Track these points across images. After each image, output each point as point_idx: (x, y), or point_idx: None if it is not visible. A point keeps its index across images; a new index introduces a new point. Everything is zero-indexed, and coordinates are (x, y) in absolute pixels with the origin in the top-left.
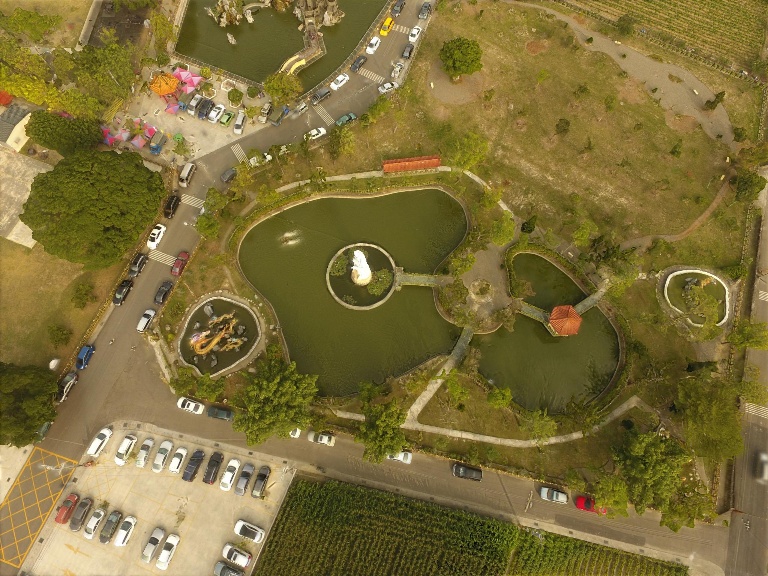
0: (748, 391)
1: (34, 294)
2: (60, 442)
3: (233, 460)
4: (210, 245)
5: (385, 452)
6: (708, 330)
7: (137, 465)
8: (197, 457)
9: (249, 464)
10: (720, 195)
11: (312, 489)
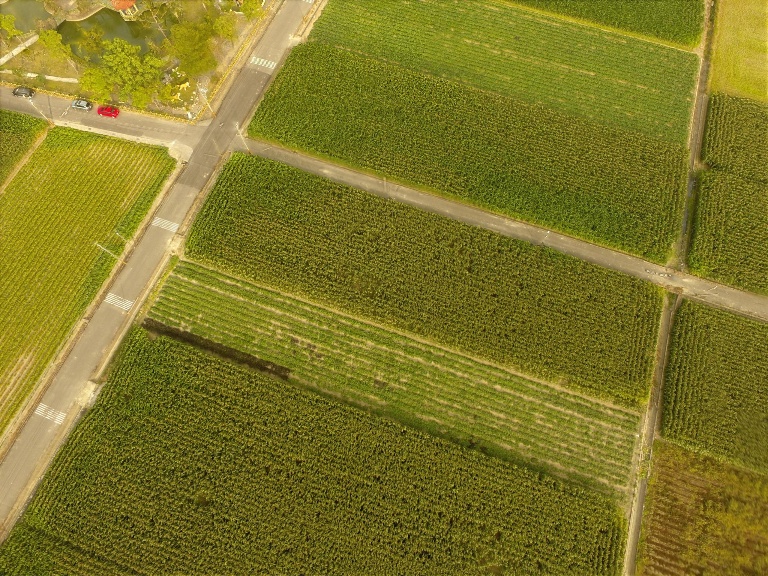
0: (217, 23)
1: None
2: None
3: None
4: None
5: None
6: None
7: None
8: None
9: None
10: None
11: None
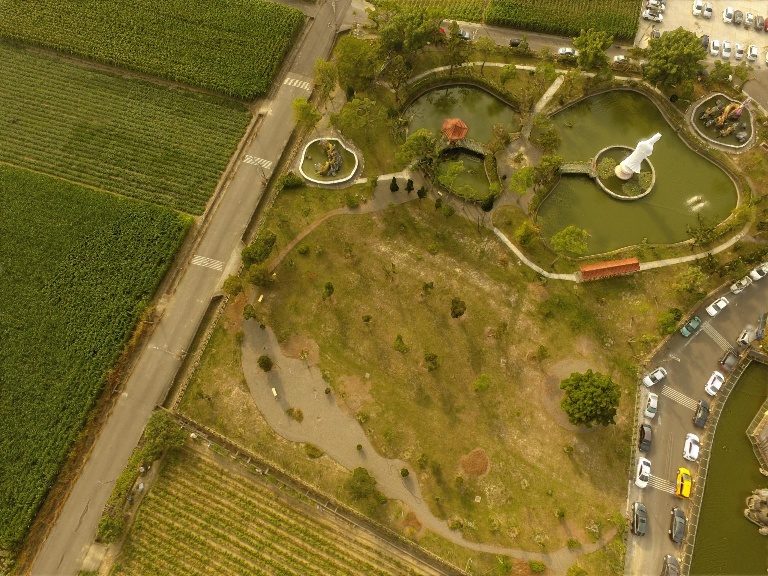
0: None
1: None
2: None
3: None
4: (766, 189)
5: (591, 32)
6: None
7: None
8: None
9: None
10: (281, 258)
11: (624, 31)
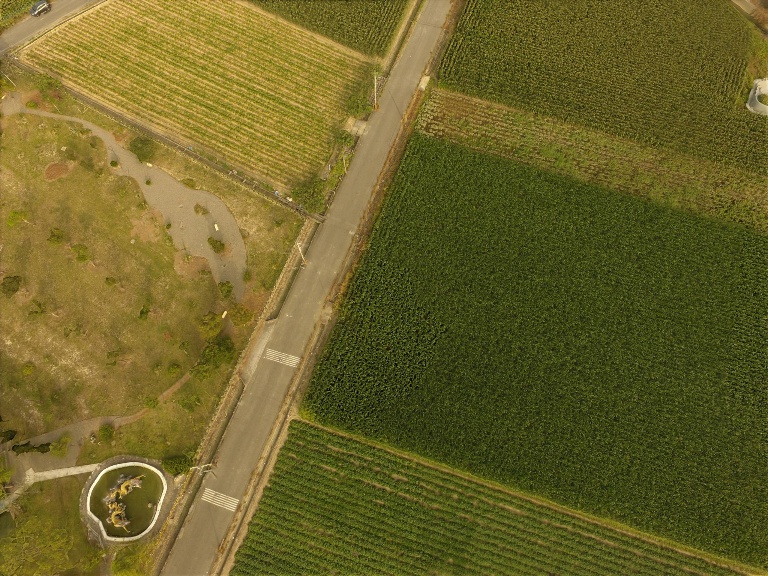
0: None
1: None
2: None
3: None
4: None
5: None
6: (52, 572)
7: None
8: None
9: None
10: None
11: None
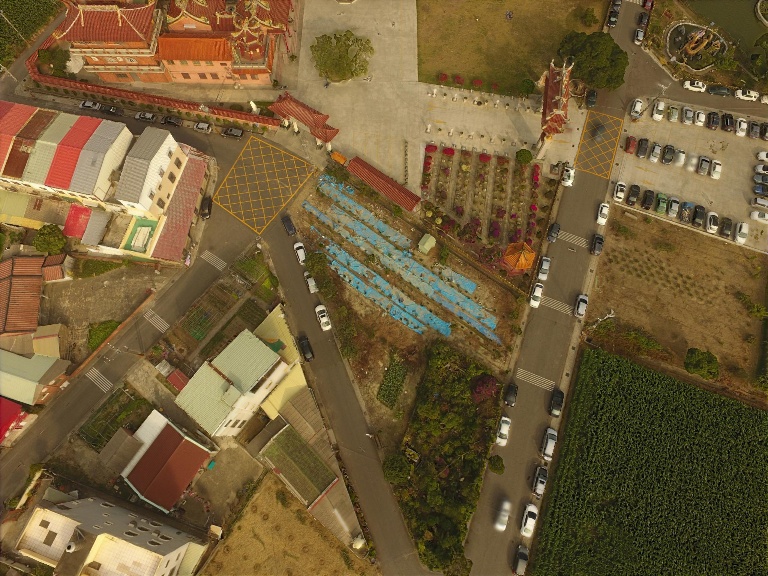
0: None
1: (545, 20)
2: (606, 108)
3: (741, 118)
4: None
5: None
6: None
7: (673, 119)
8: (715, 114)
9: (753, 121)
10: None
11: None
